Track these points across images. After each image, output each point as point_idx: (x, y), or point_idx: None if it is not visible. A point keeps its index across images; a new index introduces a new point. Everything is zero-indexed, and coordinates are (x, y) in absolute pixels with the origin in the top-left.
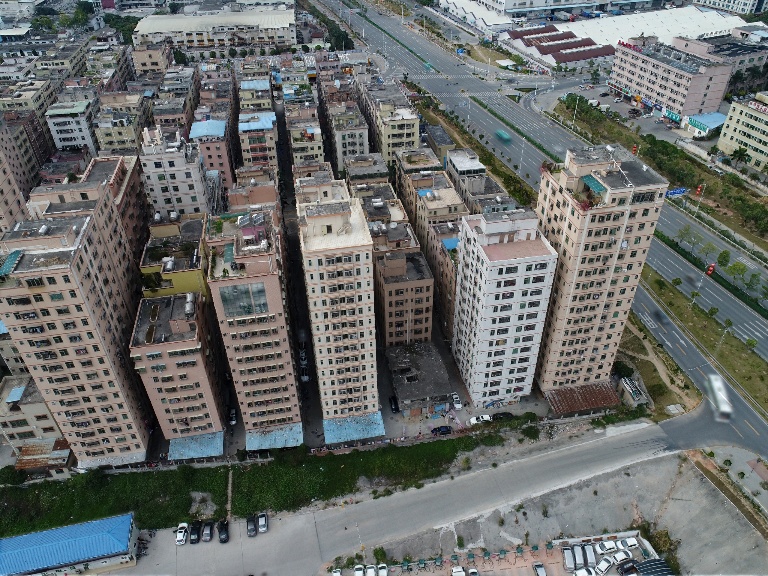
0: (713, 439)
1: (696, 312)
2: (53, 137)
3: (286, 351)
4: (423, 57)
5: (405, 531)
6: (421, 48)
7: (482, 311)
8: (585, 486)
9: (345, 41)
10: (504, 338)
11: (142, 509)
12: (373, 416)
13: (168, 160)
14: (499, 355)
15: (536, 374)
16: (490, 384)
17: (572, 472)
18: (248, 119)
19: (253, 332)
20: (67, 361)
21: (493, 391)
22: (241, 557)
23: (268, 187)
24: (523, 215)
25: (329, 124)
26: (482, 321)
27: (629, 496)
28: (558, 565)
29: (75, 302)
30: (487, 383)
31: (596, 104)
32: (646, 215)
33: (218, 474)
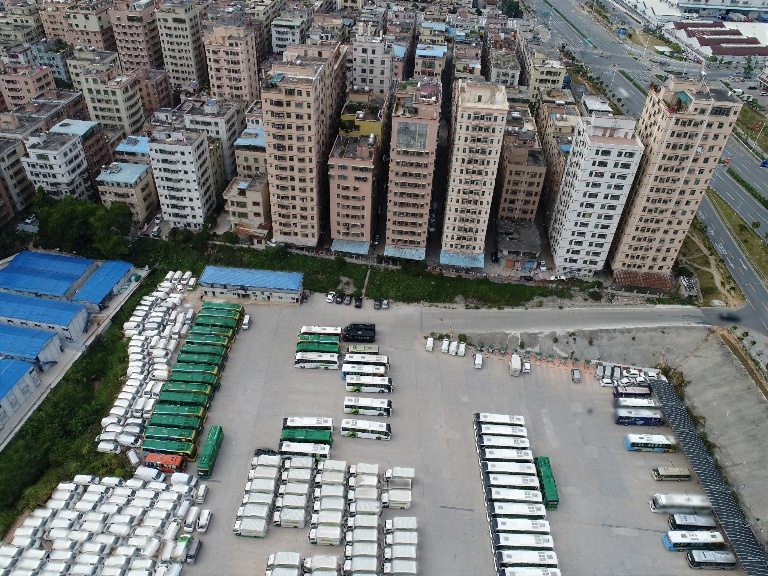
0: (742, 325)
1: (766, 250)
2: (272, 42)
3: (429, 184)
4: (585, 34)
5: (484, 329)
6: (585, 27)
7: (577, 184)
8: (627, 332)
9: (516, 10)
10: (590, 212)
11: (307, 279)
12: (478, 256)
13: (372, 48)
14: (583, 227)
15: (611, 257)
16: (572, 251)
17: (619, 322)
18: (424, 48)
19: (411, 163)
20: (290, 155)
21: (573, 259)
22: (368, 318)
23: None
24: (625, 117)
25: (488, 67)
26: (576, 193)
27: (660, 347)
28: (591, 375)
29: (308, 112)
30: (569, 250)
31: (740, 93)
32: (721, 128)
33: (361, 269)
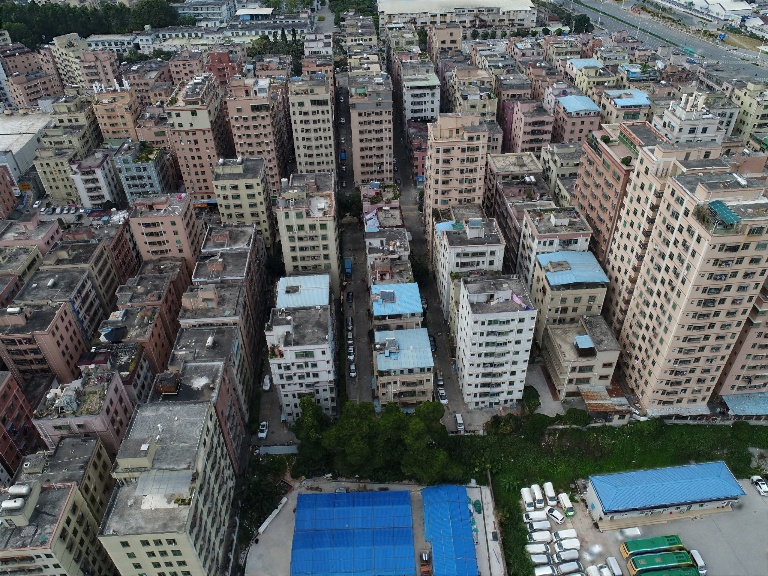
0: None
1: None
2: (406, 108)
3: None
4: (673, 42)
5: None
6: (663, 33)
7: None
8: None
9: (587, 25)
10: None
11: (704, 459)
12: None
13: (703, 126)
14: None
15: None
16: None
17: None
18: (618, 95)
19: None
20: (717, 310)
21: None
22: None
23: (761, 158)
24: None
25: None
26: None
27: None
28: None
29: None
30: None
31: None
32: None
33: None
